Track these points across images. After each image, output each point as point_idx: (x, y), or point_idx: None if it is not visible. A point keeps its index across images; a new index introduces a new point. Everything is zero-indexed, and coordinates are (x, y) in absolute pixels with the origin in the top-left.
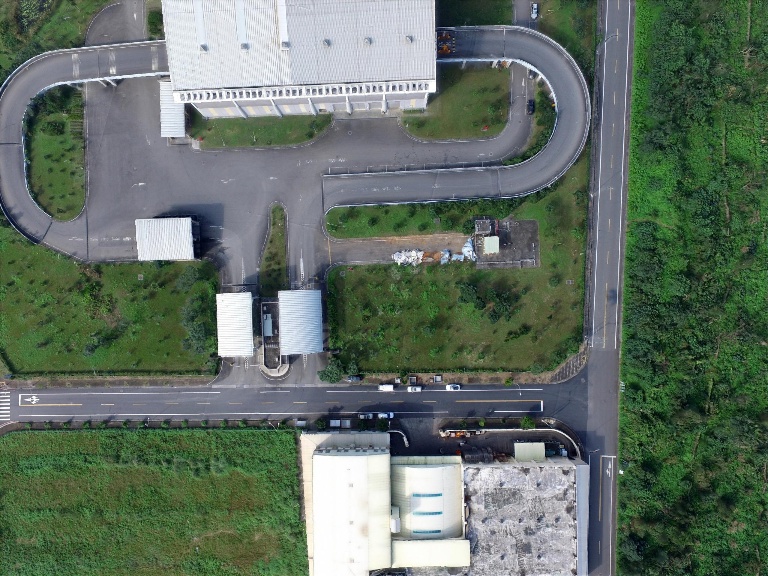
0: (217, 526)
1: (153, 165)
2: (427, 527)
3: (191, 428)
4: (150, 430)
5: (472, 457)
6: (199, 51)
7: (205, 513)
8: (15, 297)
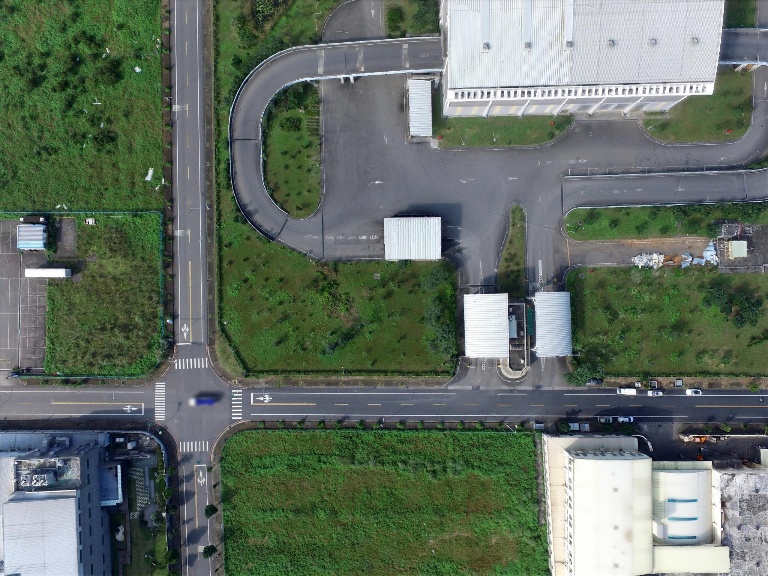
0: (454, 529)
1: (390, 163)
2: (683, 533)
3: (428, 429)
4: (386, 431)
5: (721, 463)
6: (481, 49)
7: (442, 515)
8: (249, 294)
